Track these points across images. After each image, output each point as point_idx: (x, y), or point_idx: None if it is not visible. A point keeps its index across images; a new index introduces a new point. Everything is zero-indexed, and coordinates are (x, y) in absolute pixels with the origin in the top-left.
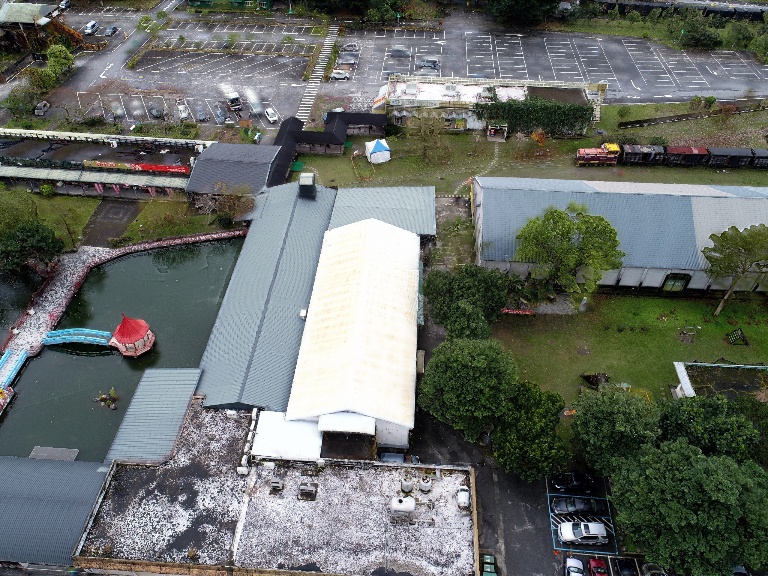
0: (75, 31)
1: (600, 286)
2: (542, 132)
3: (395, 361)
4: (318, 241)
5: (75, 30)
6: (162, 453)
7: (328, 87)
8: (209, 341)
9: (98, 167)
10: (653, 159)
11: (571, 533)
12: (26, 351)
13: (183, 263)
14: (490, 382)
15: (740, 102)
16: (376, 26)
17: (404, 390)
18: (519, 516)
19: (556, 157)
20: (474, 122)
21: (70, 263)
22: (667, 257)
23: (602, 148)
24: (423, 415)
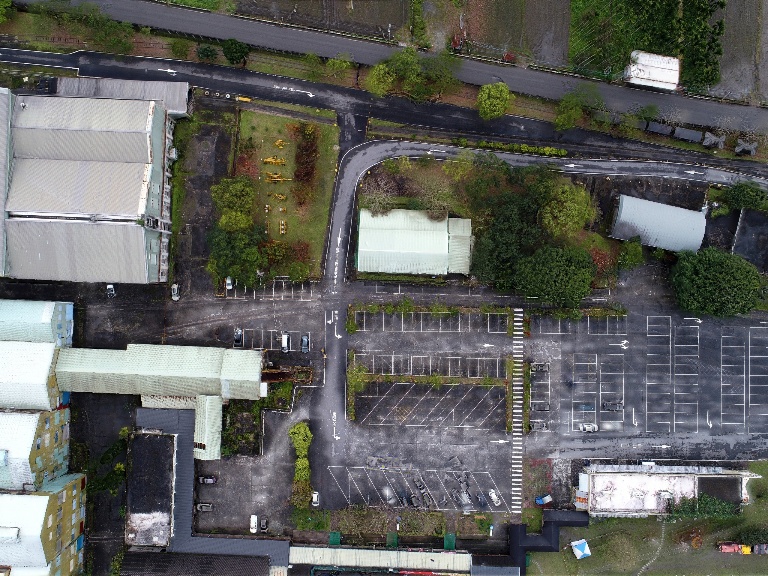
0: None
1: None
2: (700, 542)
3: None
4: None
5: None
6: None
7: (530, 444)
8: None
9: None
10: None
11: None
12: None
13: None
14: None
15: None
16: (559, 308)
17: None
18: None
19: (704, 538)
20: None
21: None
22: None
23: (739, 547)
24: None
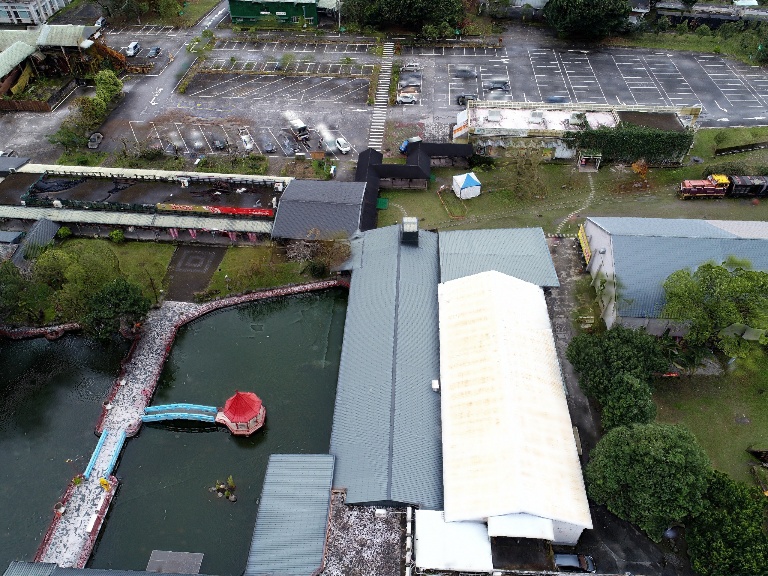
0: (118, 53)
1: None
2: (643, 163)
3: (555, 445)
4: (431, 295)
5: (118, 52)
6: (311, 565)
7: (396, 112)
8: (334, 419)
9: (173, 210)
10: (764, 191)
11: None
12: (125, 431)
13: (269, 314)
14: (688, 479)
15: None
16: (432, 43)
17: (573, 481)
18: None
19: (656, 189)
20: (563, 151)
21: (155, 322)
22: None
23: (709, 180)
24: None
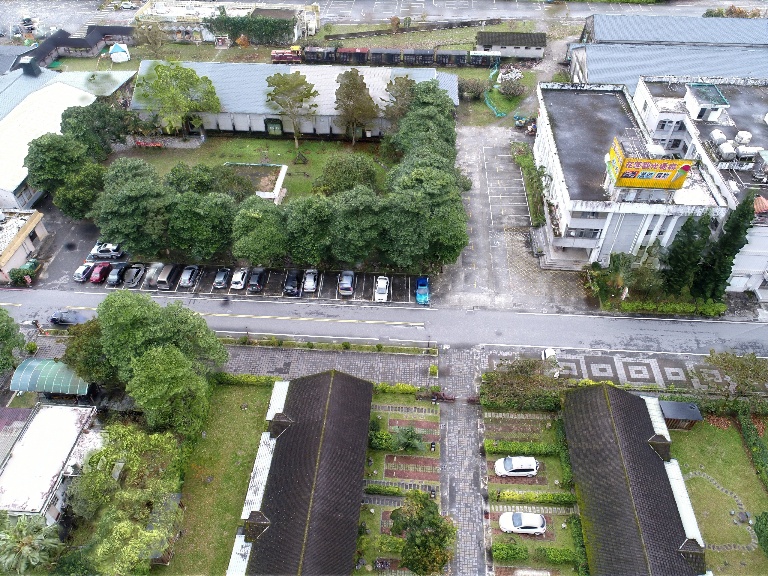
0: None
1: (225, 132)
2: (245, 37)
3: (21, 158)
4: None
5: None
6: None
7: (114, 14)
8: None
9: None
10: (327, 57)
11: (96, 250)
12: None
13: None
14: (52, 155)
15: (437, 23)
16: None
17: (18, 173)
18: (74, 246)
19: (261, 59)
20: (207, 35)
21: None
22: (263, 106)
23: None
24: (47, 199)
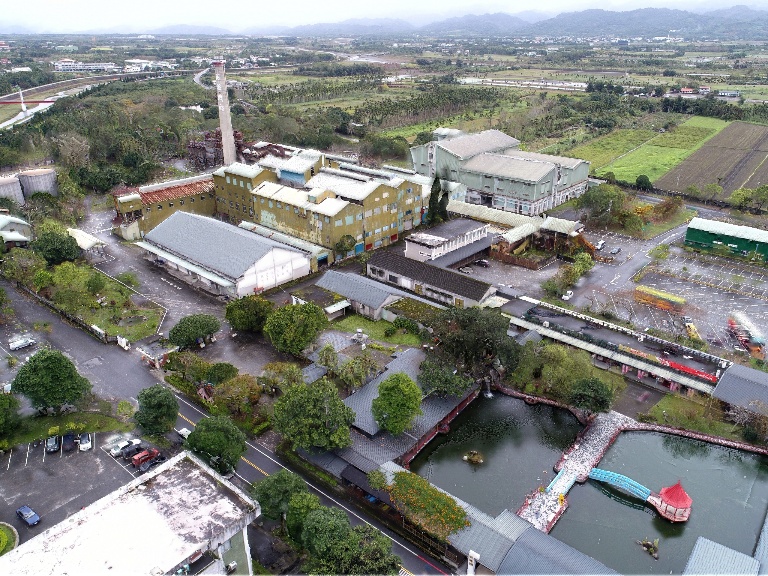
0: (592, 245)
1: None
2: None
3: None
4: None
5: (591, 244)
6: None
7: None
8: (761, 539)
9: (630, 353)
10: None
11: None
12: (577, 476)
13: None
14: None
15: None
16: None
17: None
18: None
19: None
20: None
21: (603, 420)
22: None
23: None
24: None
